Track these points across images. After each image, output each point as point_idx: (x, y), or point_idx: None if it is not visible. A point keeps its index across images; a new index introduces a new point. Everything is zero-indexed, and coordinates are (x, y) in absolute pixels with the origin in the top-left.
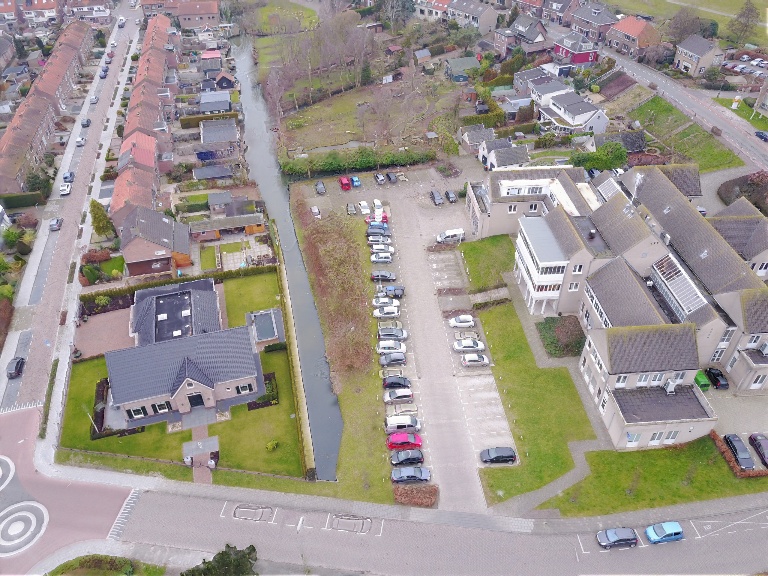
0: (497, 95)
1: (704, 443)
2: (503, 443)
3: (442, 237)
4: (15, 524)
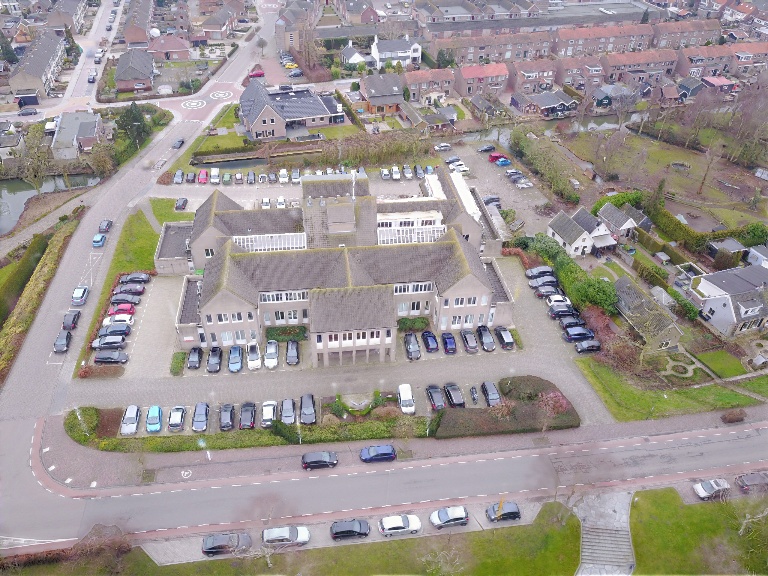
0: None
1: None
2: (192, 208)
3: None
4: (195, 103)
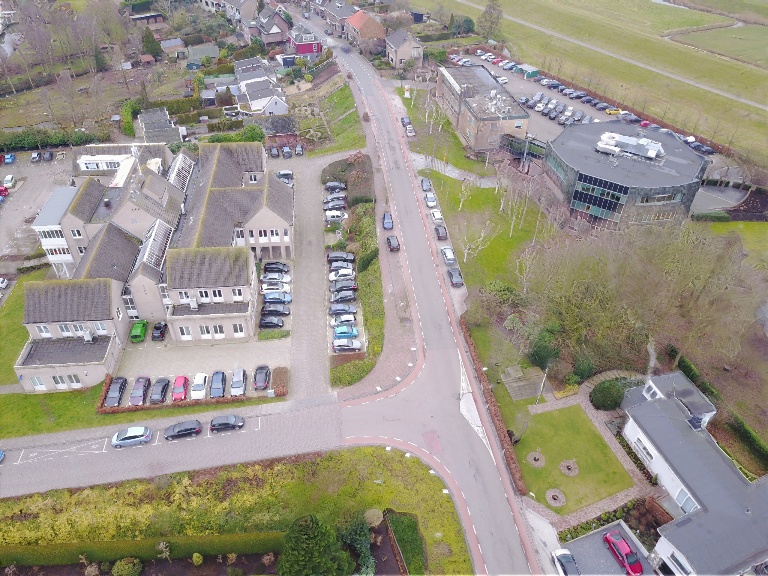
0: (214, 82)
1: (100, 386)
2: None
3: None
4: None
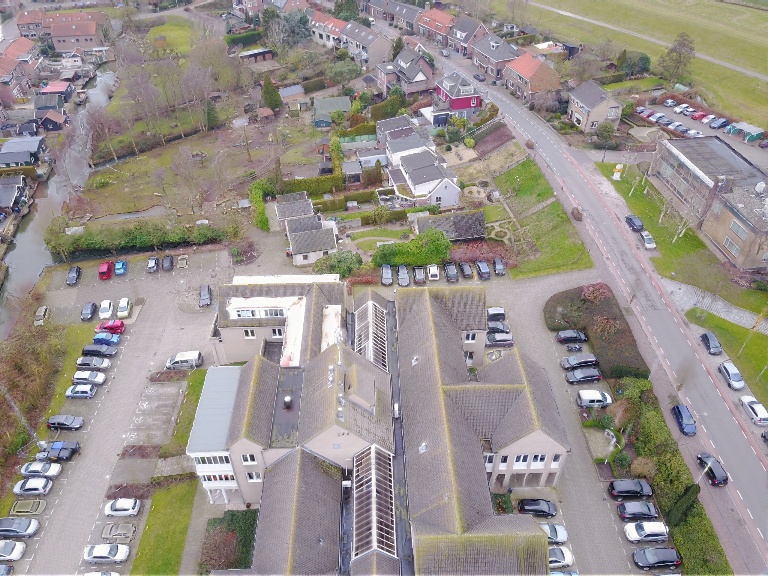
0: (352, 148)
1: None
2: None
3: (171, 361)
4: None
